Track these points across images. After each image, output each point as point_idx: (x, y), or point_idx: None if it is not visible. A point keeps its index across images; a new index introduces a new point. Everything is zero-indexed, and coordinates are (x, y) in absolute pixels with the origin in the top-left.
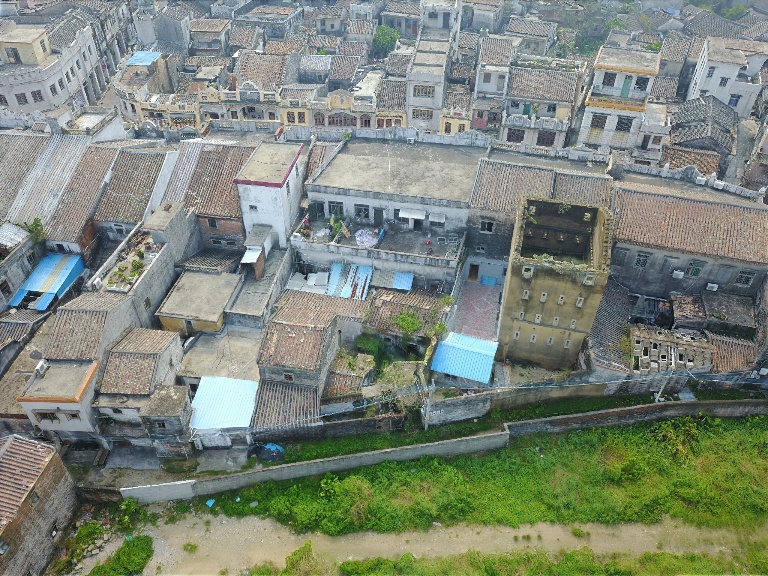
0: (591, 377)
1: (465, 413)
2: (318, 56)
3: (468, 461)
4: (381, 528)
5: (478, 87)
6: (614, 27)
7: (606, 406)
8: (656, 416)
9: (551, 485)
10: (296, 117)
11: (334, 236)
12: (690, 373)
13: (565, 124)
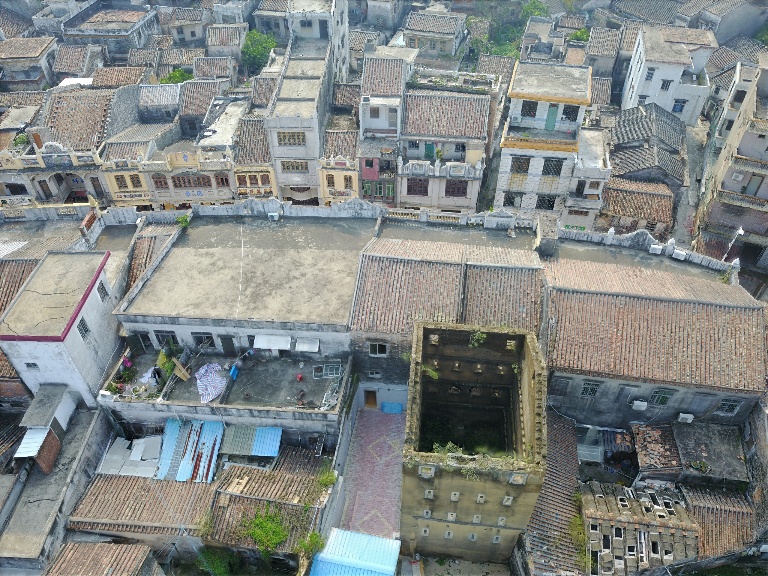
0: None
1: None
2: (162, 86)
3: None
4: None
5: (364, 124)
6: (533, 12)
7: None
8: None
9: None
10: (128, 181)
11: (165, 383)
12: (670, 574)
13: (478, 170)
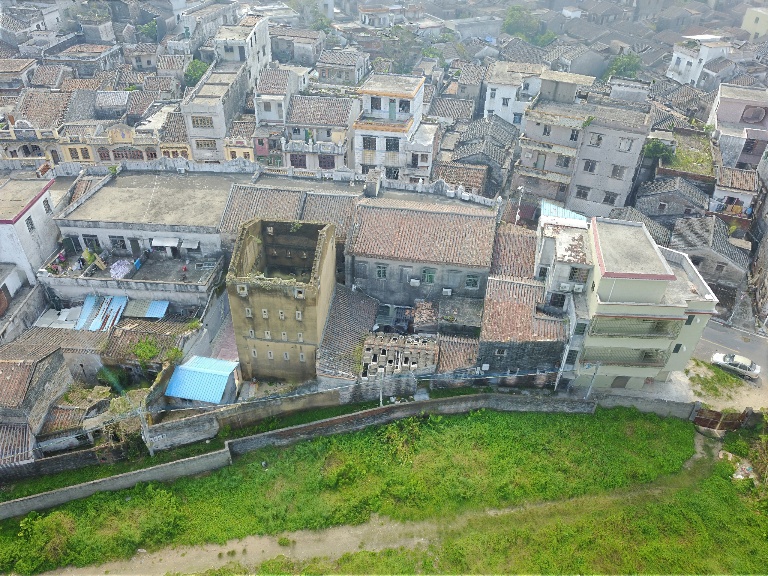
0: (320, 387)
1: (193, 435)
2: (115, 92)
3: (189, 483)
4: (80, 562)
5: (261, 116)
6: (428, 55)
7: (341, 414)
8: (385, 419)
9: (266, 498)
10: (79, 153)
11: None
12: (413, 375)
13: (340, 147)
